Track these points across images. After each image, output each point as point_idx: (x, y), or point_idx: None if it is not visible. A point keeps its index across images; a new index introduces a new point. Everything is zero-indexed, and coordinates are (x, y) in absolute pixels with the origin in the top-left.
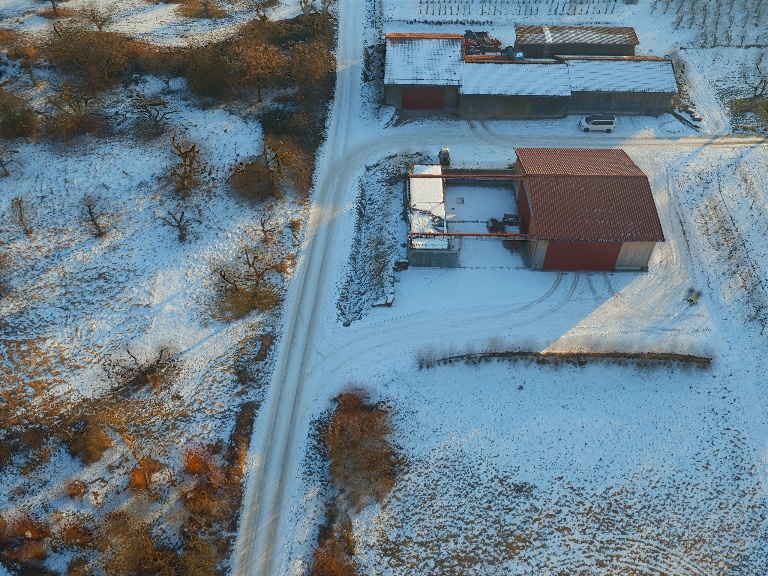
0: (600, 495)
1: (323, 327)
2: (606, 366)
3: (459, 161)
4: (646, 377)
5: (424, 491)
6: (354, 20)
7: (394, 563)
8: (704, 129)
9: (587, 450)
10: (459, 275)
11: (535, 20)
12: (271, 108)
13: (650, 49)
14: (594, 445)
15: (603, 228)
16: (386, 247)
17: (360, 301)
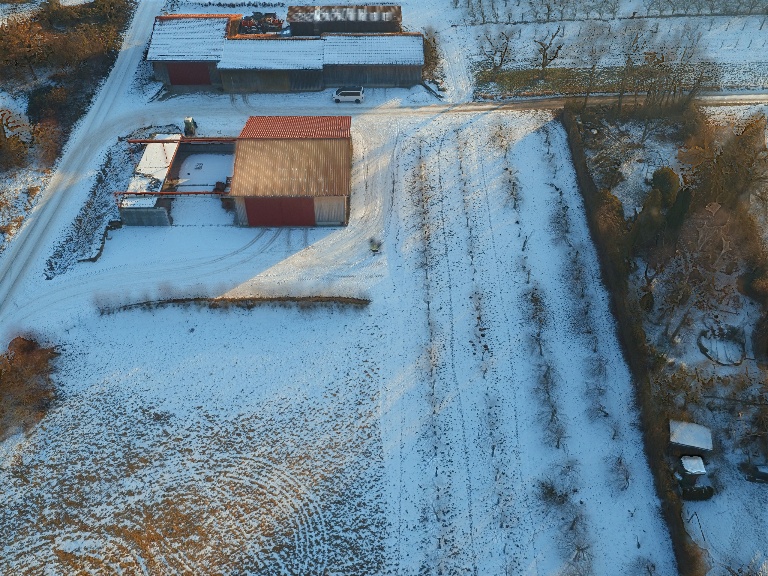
0: (230, 421)
1: (27, 281)
2: (269, 308)
3: (206, 131)
4: (308, 318)
5: (70, 421)
6: (154, 4)
7: (19, 483)
8: (446, 98)
9: (233, 383)
10: (168, 232)
11: (325, 1)
12: (44, 85)
13: (423, 27)
14: (241, 378)
15: (295, 185)
16: (108, 209)
17: (71, 258)
